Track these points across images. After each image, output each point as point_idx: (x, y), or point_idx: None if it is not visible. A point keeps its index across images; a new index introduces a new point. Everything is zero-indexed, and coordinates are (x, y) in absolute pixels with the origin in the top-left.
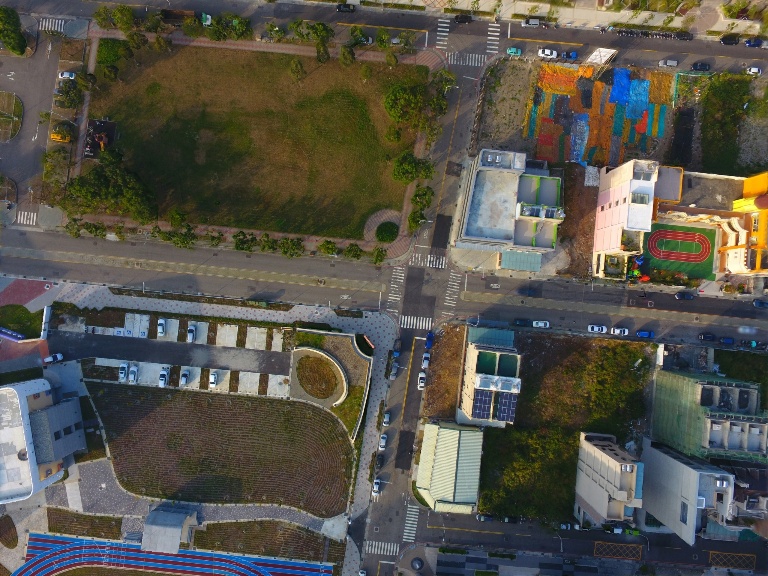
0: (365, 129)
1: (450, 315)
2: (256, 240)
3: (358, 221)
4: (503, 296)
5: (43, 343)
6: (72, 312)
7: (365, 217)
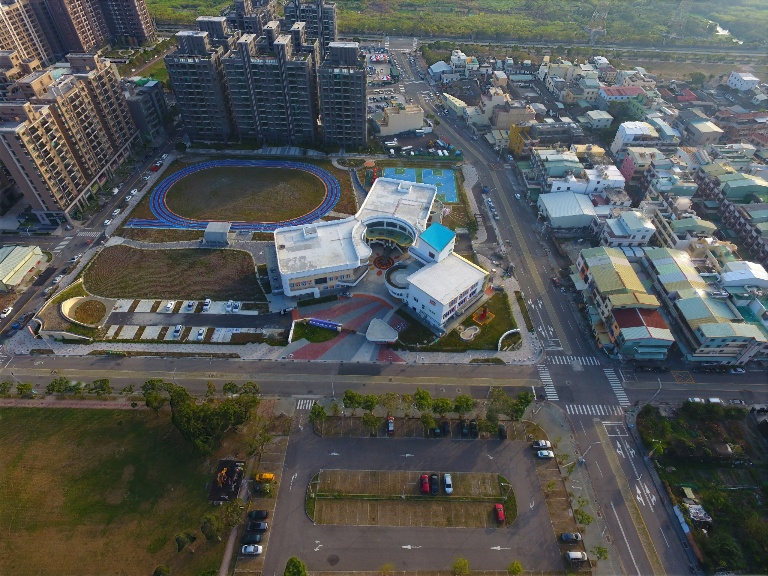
0: None
1: None
2: None
3: None
4: None
5: None
6: (271, 340)
7: None
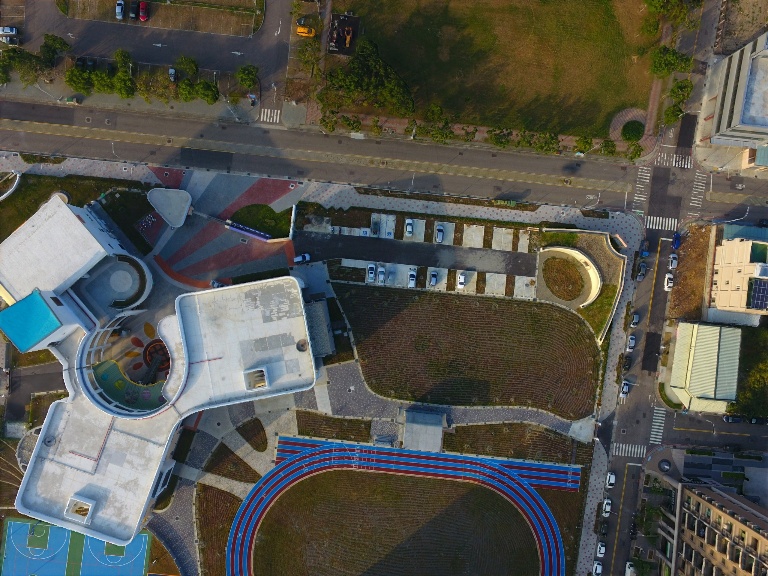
0: (610, 26)
1: (696, 216)
2: (511, 135)
3: (604, 120)
4: (748, 196)
5: (289, 244)
6: (318, 212)
7: (611, 116)
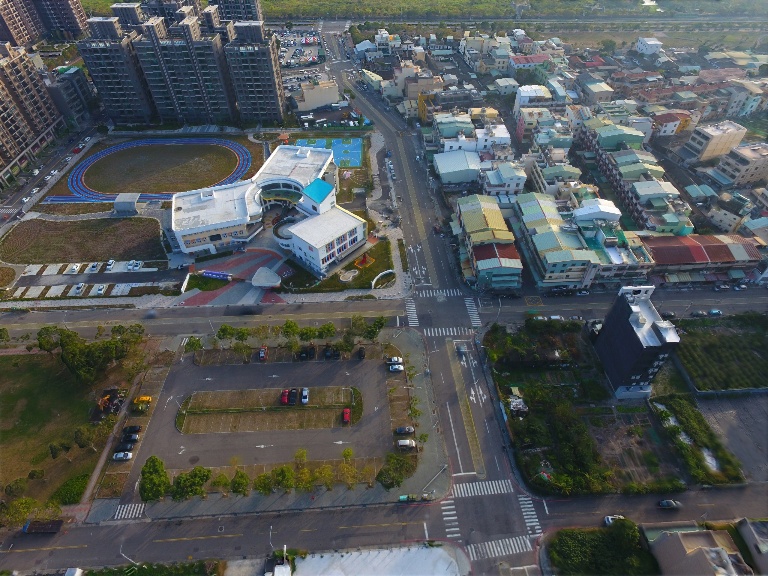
0: None
1: None
2: None
3: None
4: None
5: None
6: (166, 291)
7: None
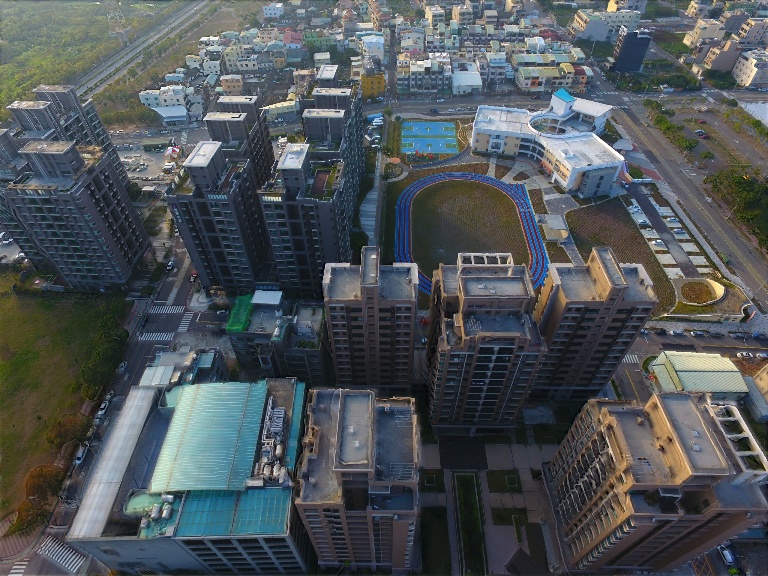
0: None
1: None
2: None
3: None
4: None
5: (629, 182)
6: (654, 189)
7: None
